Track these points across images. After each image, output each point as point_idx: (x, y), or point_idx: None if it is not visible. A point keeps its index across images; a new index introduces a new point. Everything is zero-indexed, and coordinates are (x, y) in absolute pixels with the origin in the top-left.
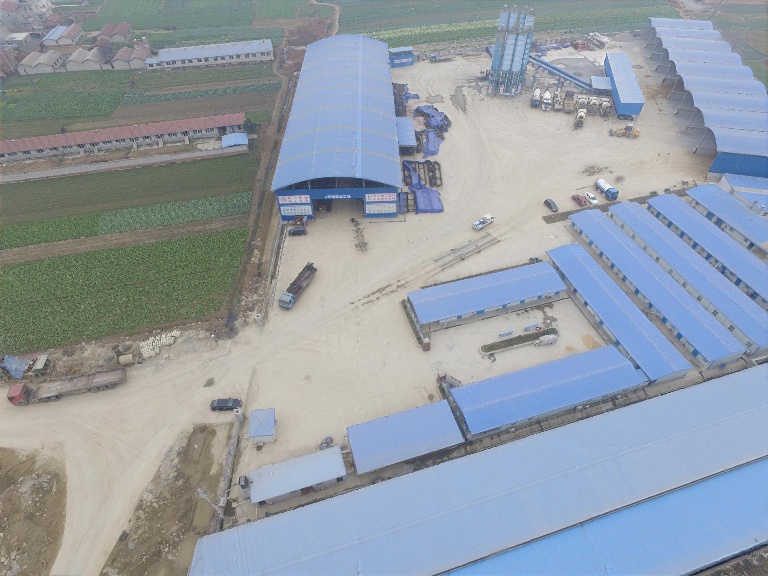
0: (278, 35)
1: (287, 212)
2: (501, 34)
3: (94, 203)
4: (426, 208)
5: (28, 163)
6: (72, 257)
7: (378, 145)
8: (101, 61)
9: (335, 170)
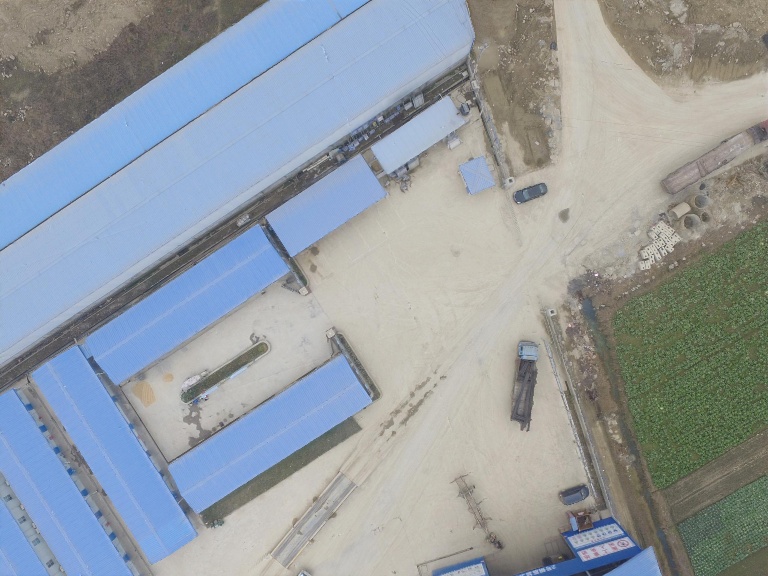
0: None
1: (609, 530)
2: None
3: None
4: None
5: None
6: None
7: None
8: None
9: None
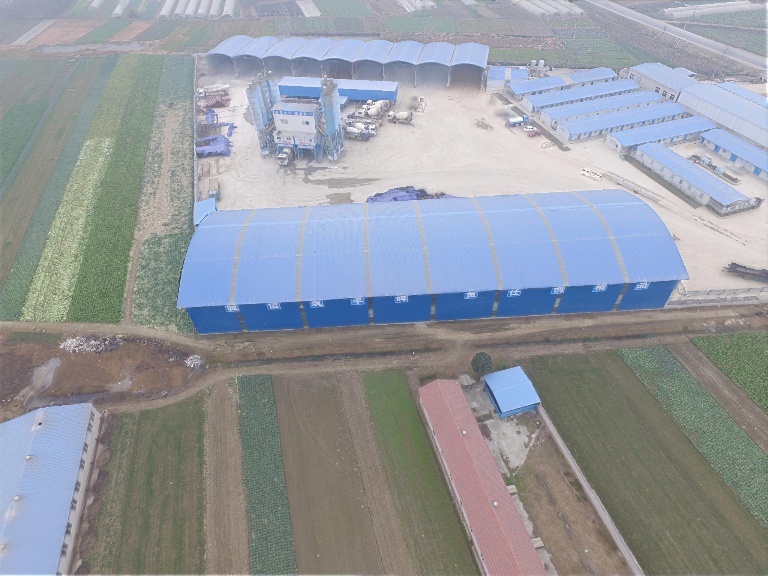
0: None
1: None
2: None
3: None
4: None
5: None
6: None
7: (560, 199)
8: None
9: (646, 216)
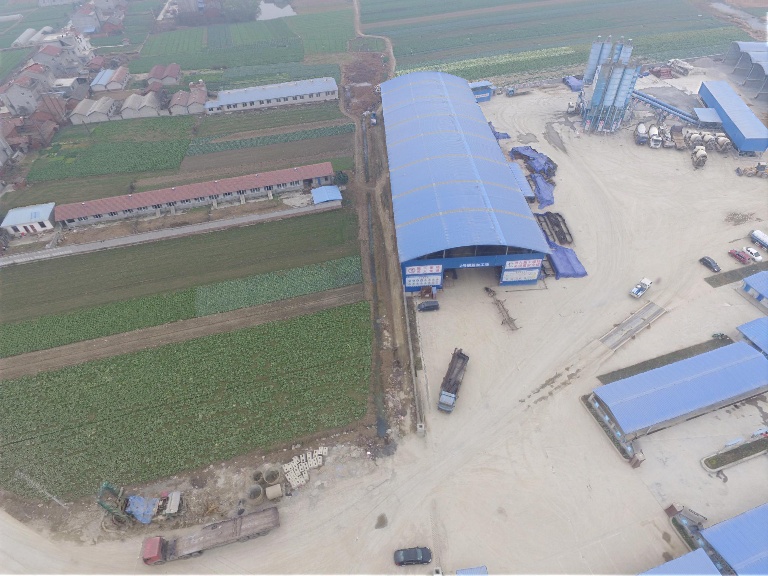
0: (335, 71)
1: (412, 283)
2: (607, 68)
3: (184, 276)
4: (567, 272)
5: (100, 228)
6: (174, 347)
7: (507, 201)
8: (157, 107)
9: (475, 236)
